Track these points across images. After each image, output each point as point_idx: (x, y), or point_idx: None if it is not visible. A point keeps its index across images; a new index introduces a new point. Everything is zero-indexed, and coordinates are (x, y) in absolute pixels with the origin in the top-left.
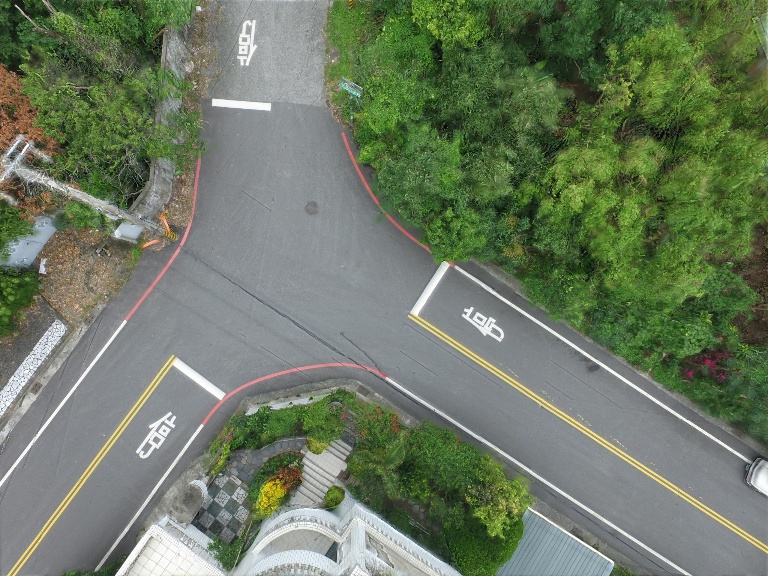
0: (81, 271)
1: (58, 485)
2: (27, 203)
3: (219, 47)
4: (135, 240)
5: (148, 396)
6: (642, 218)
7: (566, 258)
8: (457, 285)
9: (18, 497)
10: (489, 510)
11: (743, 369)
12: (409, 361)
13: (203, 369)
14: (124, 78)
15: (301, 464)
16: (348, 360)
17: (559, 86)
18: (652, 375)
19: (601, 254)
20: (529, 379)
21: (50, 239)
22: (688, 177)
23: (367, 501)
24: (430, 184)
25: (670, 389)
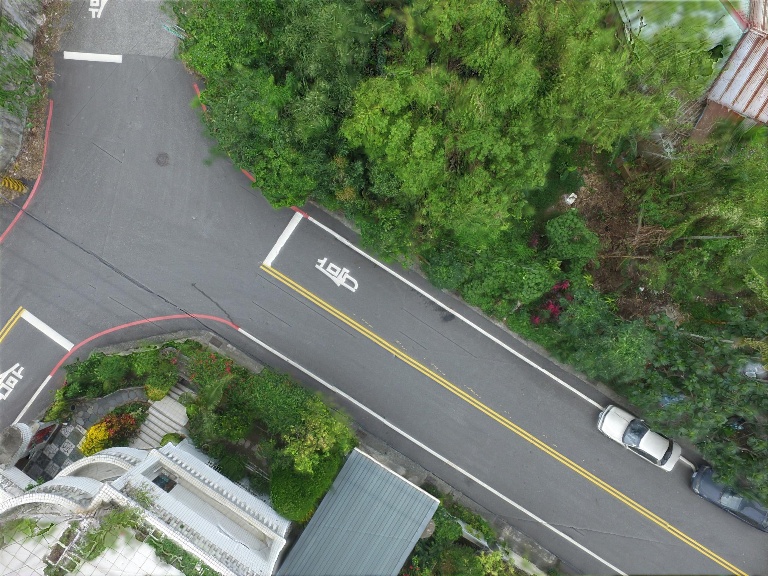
0: None
1: None
2: None
3: None
4: None
5: None
6: (441, 150)
7: (401, 202)
8: (311, 236)
9: None
10: (299, 445)
11: (570, 309)
12: (262, 312)
13: (51, 320)
14: None
15: (145, 413)
16: (200, 311)
17: (420, 39)
18: (507, 324)
19: None
20: (383, 329)
21: None
22: (544, 127)
23: (206, 447)
24: (239, 121)
25: (525, 338)
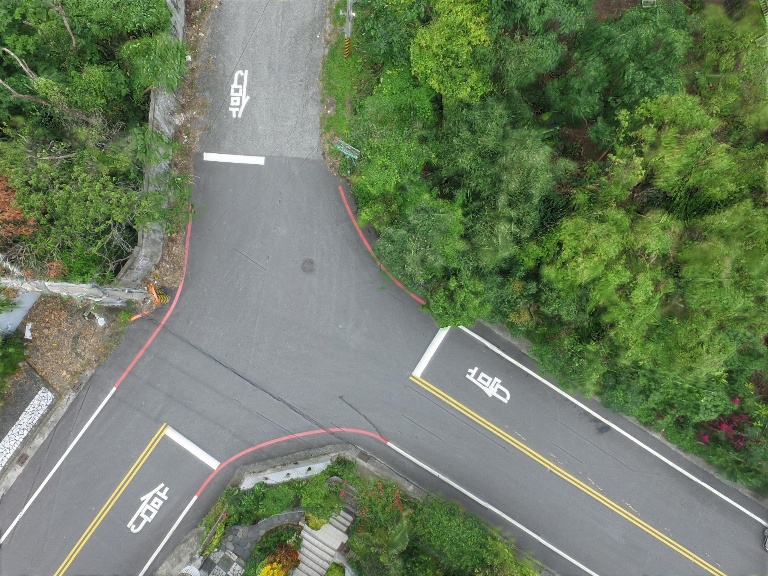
0: (68, 336)
1: (46, 562)
2: (7, 279)
3: (210, 98)
4: (124, 303)
5: (139, 467)
6: (657, 295)
7: (575, 322)
8: (460, 344)
9: (4, 575)
10: None
11: (763, 441)
12: (411, 425)
13: (196, 437)
14: (107, 151)
15: (299, 538)
16: (348, 425)
17: (564, 132)
18: (665, 436)
19: (611, 316)
20: (537, 442)
21: (36, 302)
22: (700, 228)
23: None
24: (432, 257)
25: (684, 450)
